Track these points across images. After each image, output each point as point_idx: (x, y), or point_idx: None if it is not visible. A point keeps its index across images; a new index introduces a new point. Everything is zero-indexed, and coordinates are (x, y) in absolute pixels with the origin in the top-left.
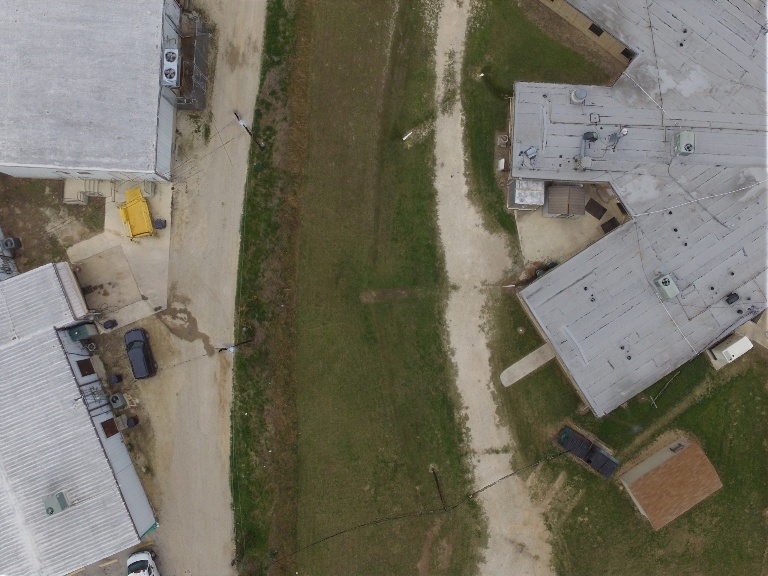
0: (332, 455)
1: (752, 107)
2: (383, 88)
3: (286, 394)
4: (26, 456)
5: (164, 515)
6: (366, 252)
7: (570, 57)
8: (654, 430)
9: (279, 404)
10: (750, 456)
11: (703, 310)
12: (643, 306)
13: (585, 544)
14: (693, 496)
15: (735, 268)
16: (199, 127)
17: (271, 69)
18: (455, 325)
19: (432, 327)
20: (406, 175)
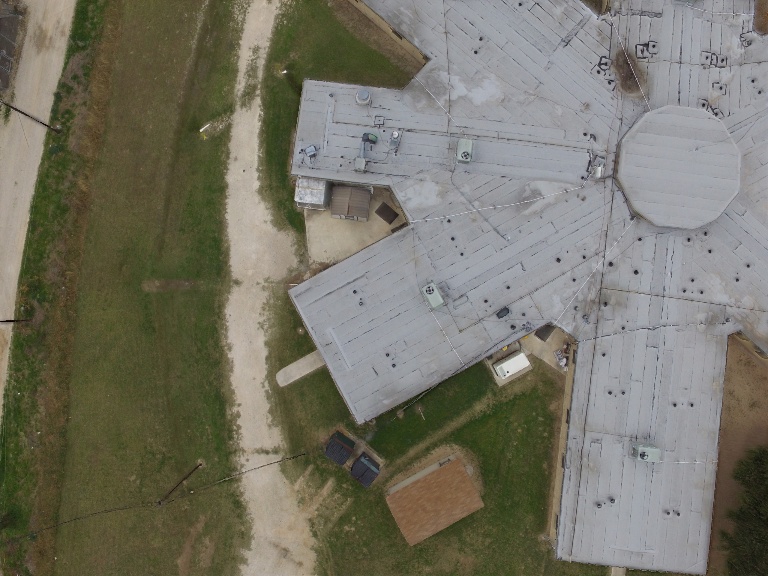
0: (101, 442)
1: (544, 119)
2: (185, 79)
3: (59, 377)
4: None
5: None
6: (152, 240)
7: (375, 59)
8: (429, 443)
9: (52, 386)
10: (529, 478)
11: (474, 322)
12: (411, 314)
13: (350, 555)
14: (451, 514)
15: (512, 282)
16: (0, 106)
17: (76, 54)
18: (234, 320)
19: (211, 320)
20: (199, 166)
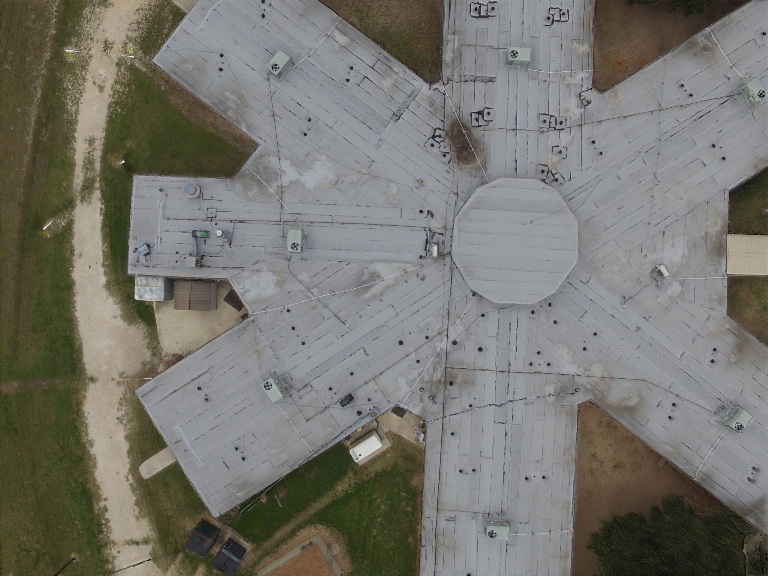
0: None
1: (379, 199)
2: (24, 177)
3: None
4: None
5: None
6: (6, 343)
7: (213, 142)
8: (294, 525)
9: None
10: (395, 552)
11: (320, 411)
12: (256, 407)
13: None
14: None
15: (356, 367)
16: None
17: None
18: (93, 417)
19: (70, 419)
20: (45, 266)
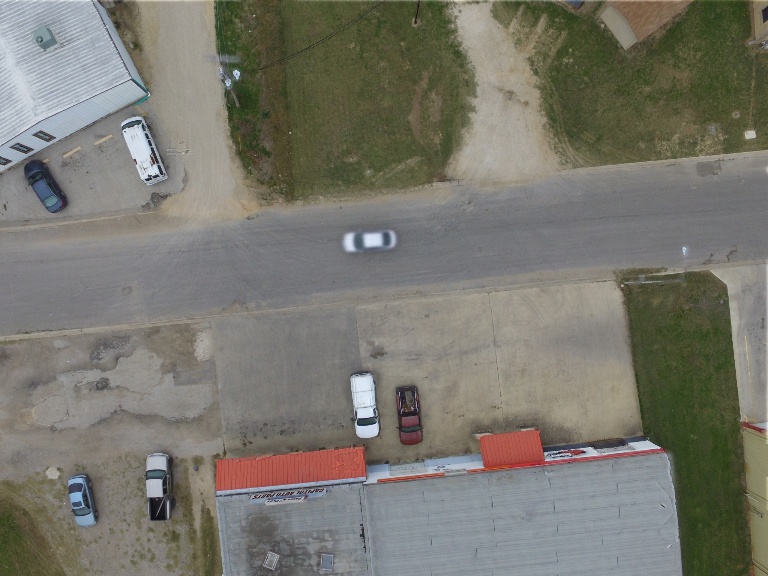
0: (315, 16)
1: None
2: None
3: None
4: (13, 3)
5: (155, 87)
6: None
7: None
8: None
9: None
10: None
11: None
12: None
13: (572, 85)
14: (672, 4)
15: None
16: None
17: None
18: None
19: None
20: None
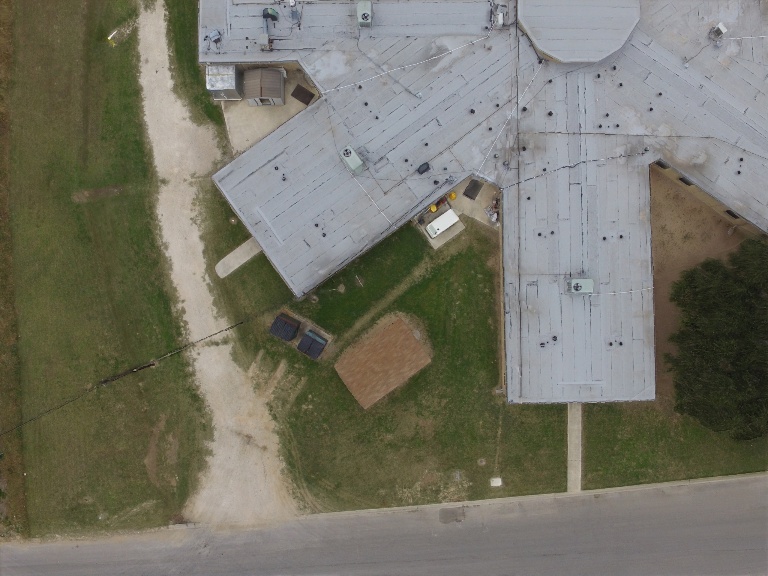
0: (53, 356)
1: None
2: None
3: (3, 297)
4: None
5: None
6: (76, 153)
7: None
8: (374, 313)
9: None
10: (475, 335)
11: (397, 183)
12: (334, 182)
13: (311, 432)
14: (400, 372)
15: (430, 139)
16: None
17: None
18: (167, 219)
19: (144, 223)
20: (112, 74)
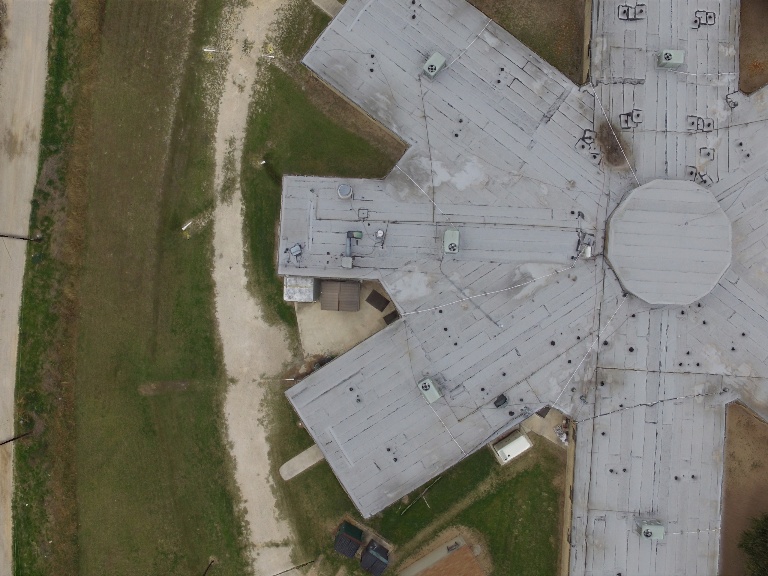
0: (112, 546)
1: (530, 200)
2: (163, 177)
3: (65, 486)
4: None
5: None
6: (144, 344)
7: (354, 143)
8: (436, 525)
9: (58, 496)
10: (536, 552)
11: (472, 411)
12: (409, 408)
13: None
14: None
15: (508, 368)
16: None
17: (49, 158)
18: (233, 418)
19: (210, 420)
20: (185, 266)
